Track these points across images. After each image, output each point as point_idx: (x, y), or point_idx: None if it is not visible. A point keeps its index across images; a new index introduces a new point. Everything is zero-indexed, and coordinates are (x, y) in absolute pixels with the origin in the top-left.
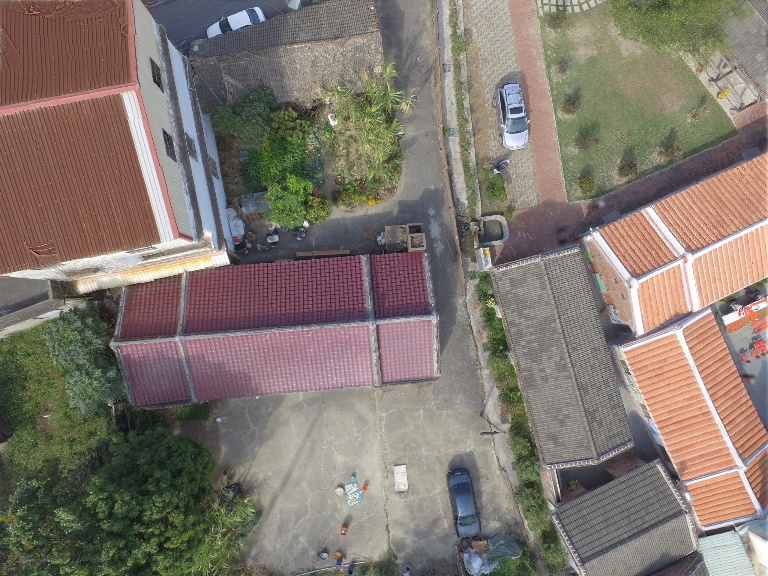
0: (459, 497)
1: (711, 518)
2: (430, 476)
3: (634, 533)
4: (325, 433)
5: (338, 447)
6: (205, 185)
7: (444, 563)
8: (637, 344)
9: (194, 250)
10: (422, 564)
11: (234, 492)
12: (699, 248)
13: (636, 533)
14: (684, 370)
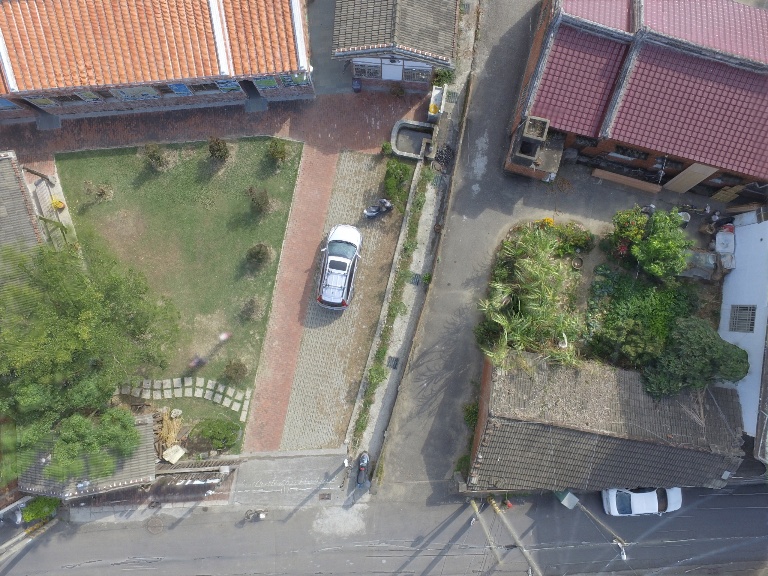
0: None
1: None
2: None
3: None
4: None
5: None
6: None
7: None
8: None
9: None
10: None
11: None
12: None
13: None
14: None
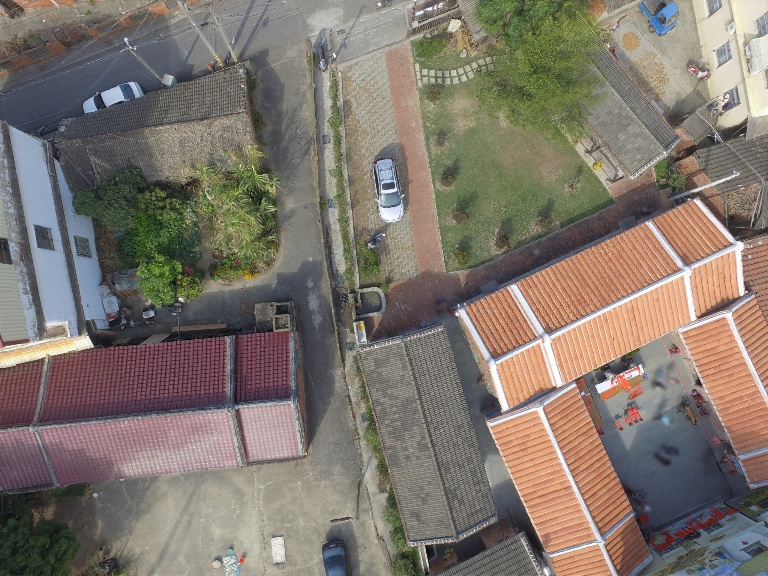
0: (332, 570)
1: None
2: (308, 547)
3: None
4: (203, 506)
5: (216, 520)
6: (64, 271)
7: None
8: (502, 420)
9: (50, 339)
10: None
11: (110, 567)
12: (557, 328)
13: None
14: (546, 446)
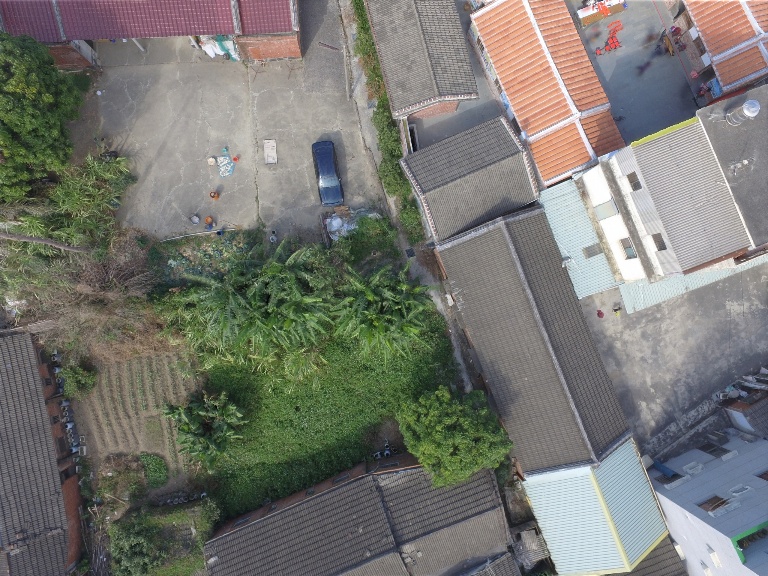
0: (321, 160)
1: (552, 172)
2: (298, 151)
3: (473, 170)
4: (200, 109)
5: (212, 123)
6: None
7: (309, 232)
8: (485, 8)
9: None
10: (289, 232)
11: (110, 156)
12: None
13: (475, 169)
14: (527, 29)
